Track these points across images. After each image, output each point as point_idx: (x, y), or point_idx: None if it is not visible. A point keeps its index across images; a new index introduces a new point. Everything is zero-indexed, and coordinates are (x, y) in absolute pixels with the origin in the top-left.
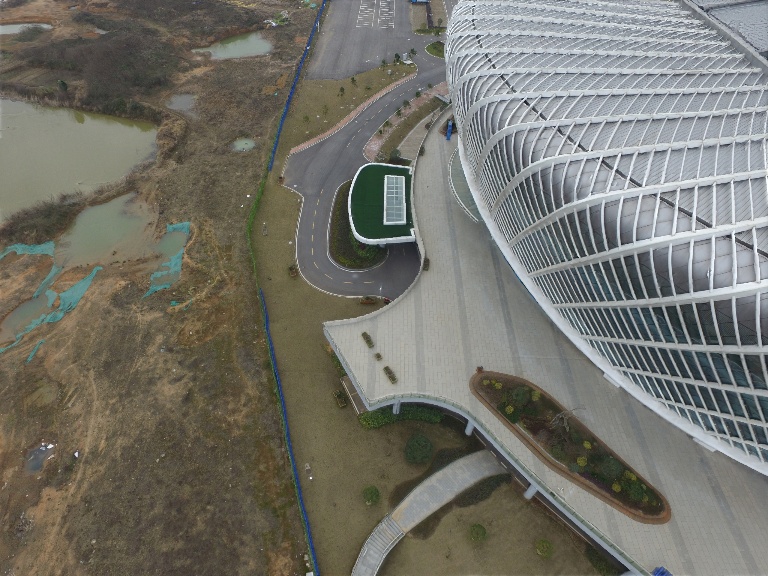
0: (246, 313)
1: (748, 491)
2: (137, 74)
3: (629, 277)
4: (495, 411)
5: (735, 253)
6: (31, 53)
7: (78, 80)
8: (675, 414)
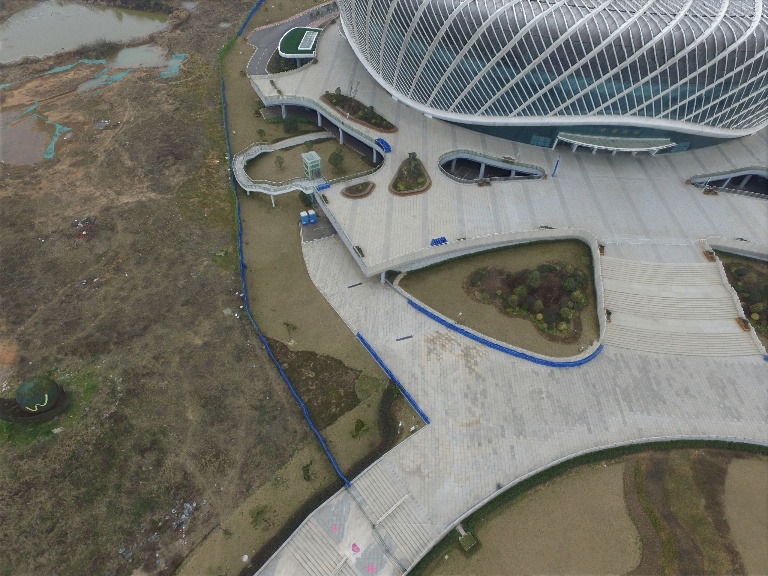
0: (213, 87)
1: (440, 128)
2: None
3: None
4: (328, 104)
5: None
6: None
7: None
8: (415, 102)
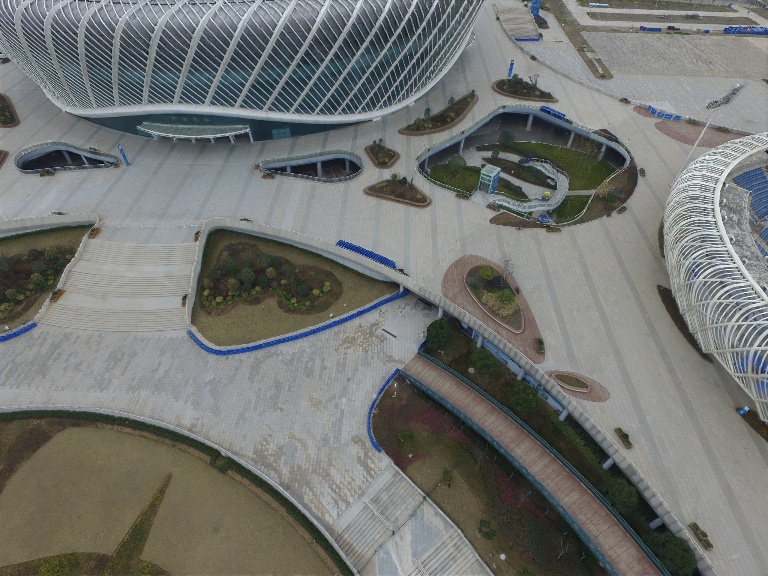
0: None
1: None
2: None
3: None
4: None
5: None
6: None
7: None
8: None
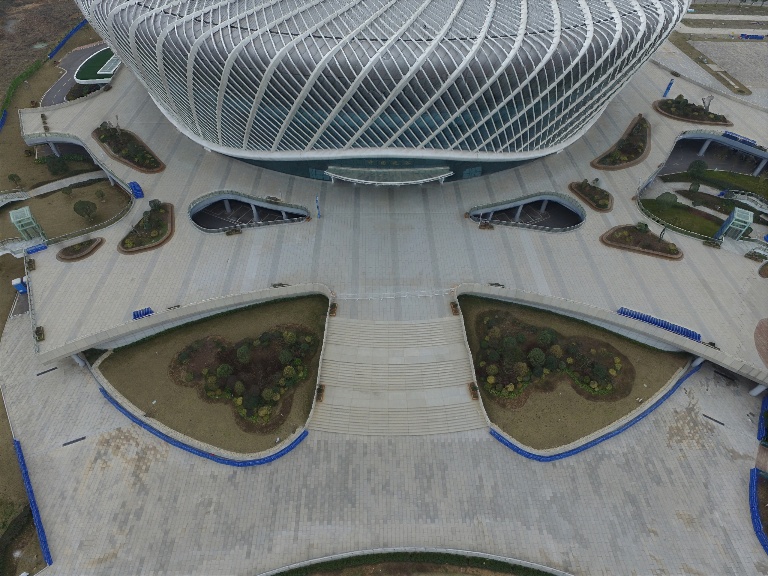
0: None
1: (215, 163)
2: None
3: None
4: None
5: None
6: None
7: None
8: (193, 134)
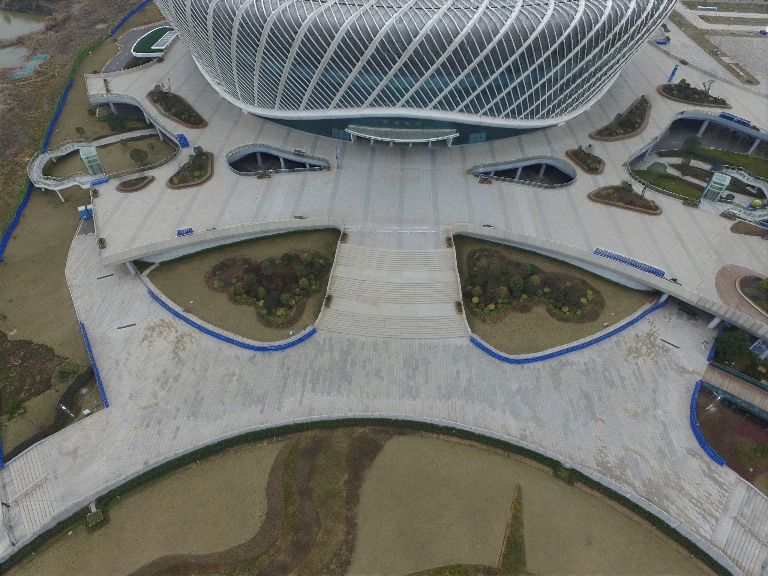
0: (60, 86)
1: (251, 123)
2: None
3: None
4: (151, 101)
5: None
6: None
7: None
8: (233, 98)
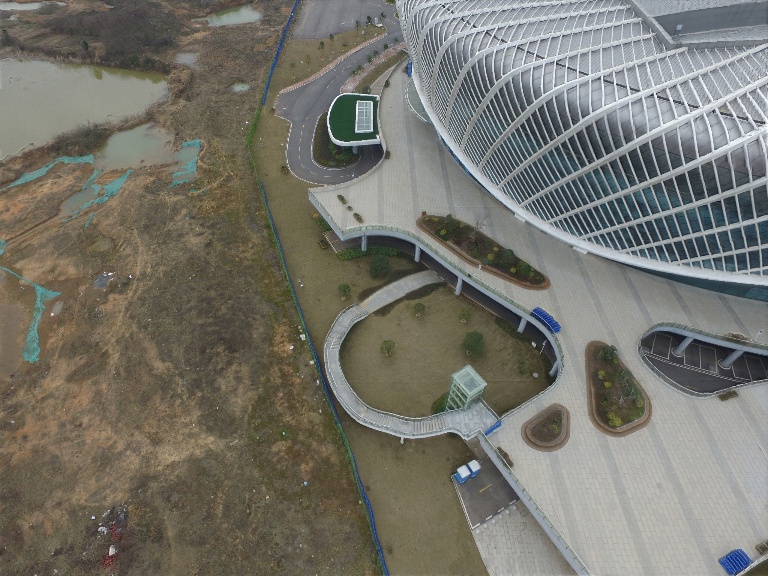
0: (249, 196)
1: (606, 273)
2: (147, 36)
3: (504, 105)
4: (433, 236)
5: (554, 70)
6: (52, 23)
7: (96, 43)
8: (560, 230)
